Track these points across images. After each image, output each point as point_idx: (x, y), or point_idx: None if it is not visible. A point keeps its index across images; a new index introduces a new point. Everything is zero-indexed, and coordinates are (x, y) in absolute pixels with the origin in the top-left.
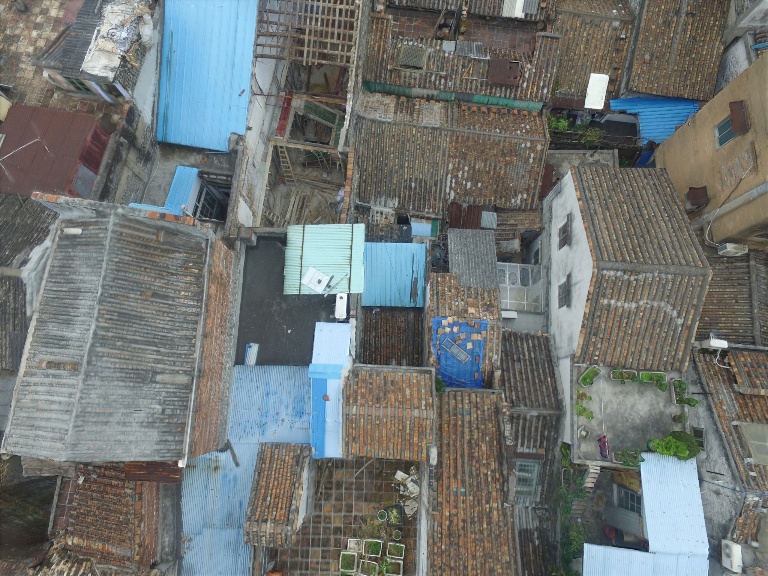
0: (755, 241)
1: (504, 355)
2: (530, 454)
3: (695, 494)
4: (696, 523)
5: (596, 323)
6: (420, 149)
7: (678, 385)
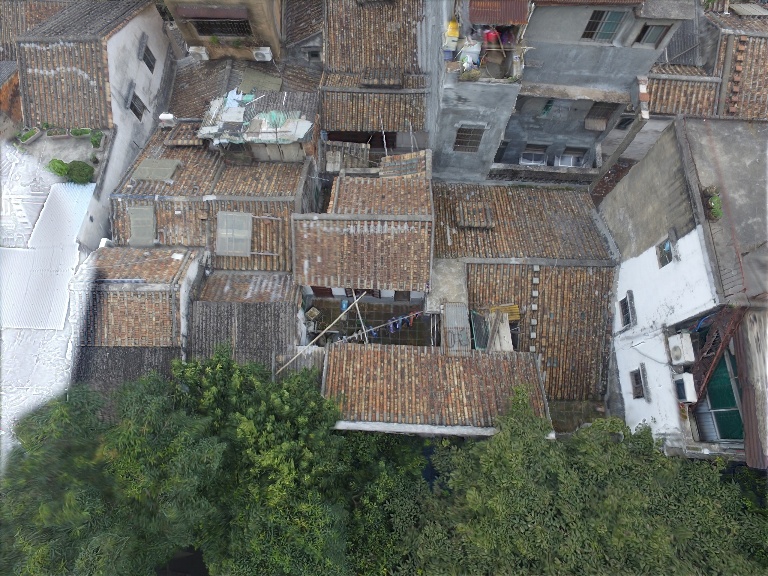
0: (207, 41)
1: (15, 151)
2: (8, 216)
3: (84, 207)
4: (75, 225)
5: (30, 91)
6: (3, 19)
7: (91, 132)
